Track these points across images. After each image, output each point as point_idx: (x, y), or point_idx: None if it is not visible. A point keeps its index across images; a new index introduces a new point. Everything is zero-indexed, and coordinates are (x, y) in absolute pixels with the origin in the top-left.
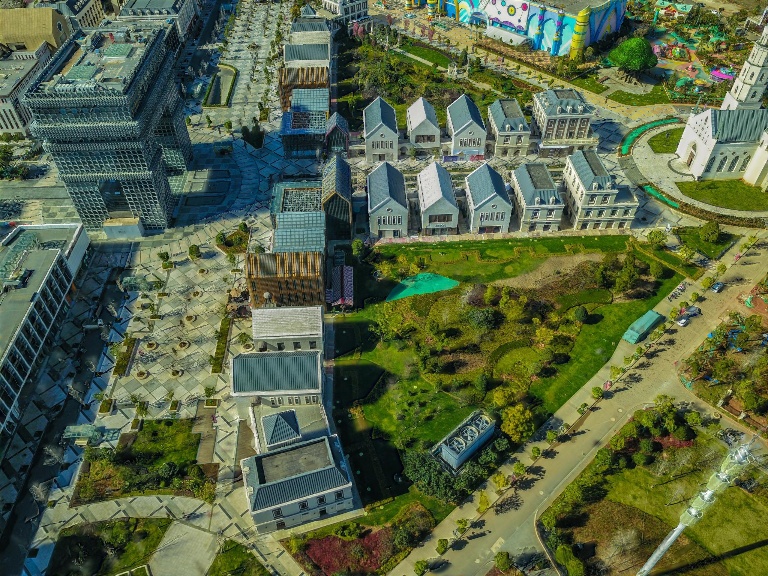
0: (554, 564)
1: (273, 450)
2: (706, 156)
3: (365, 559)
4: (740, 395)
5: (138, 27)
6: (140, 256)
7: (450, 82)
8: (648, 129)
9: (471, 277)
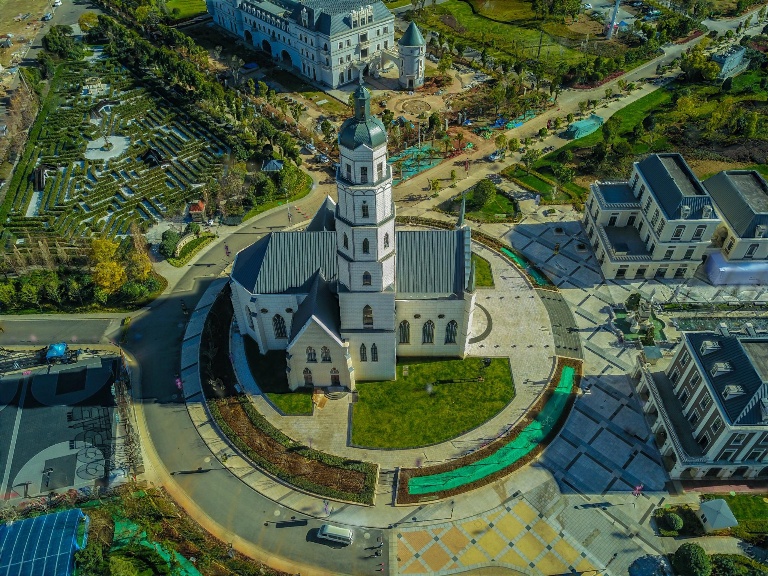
0: None
1: None
2: None
3: (761, 43)
4: None
5: None
6: None
7: None
8: (502, 443)
9: None
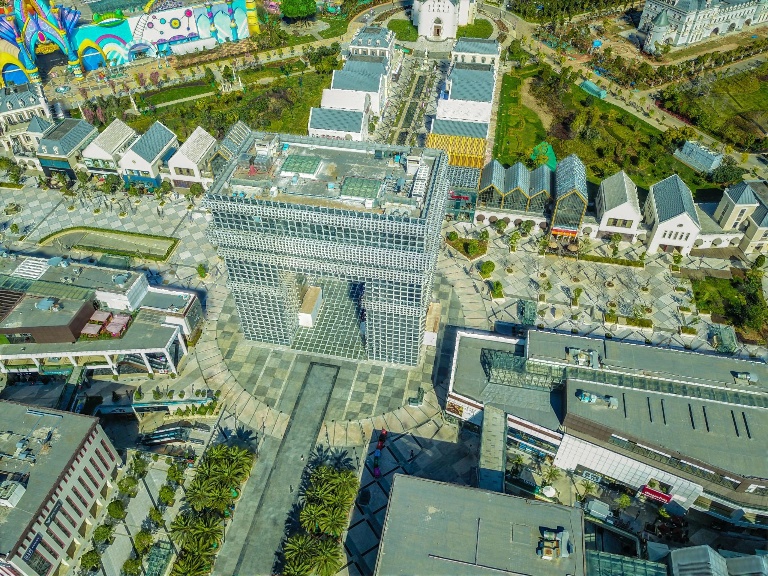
0: (764, 153)
1: (762, 201)
2: (456, 18)
3: None
4: (652, 75)
5: (241, 148)
6: (473, 319)
7: (246, 93)
8: None
9: (538, 136)
